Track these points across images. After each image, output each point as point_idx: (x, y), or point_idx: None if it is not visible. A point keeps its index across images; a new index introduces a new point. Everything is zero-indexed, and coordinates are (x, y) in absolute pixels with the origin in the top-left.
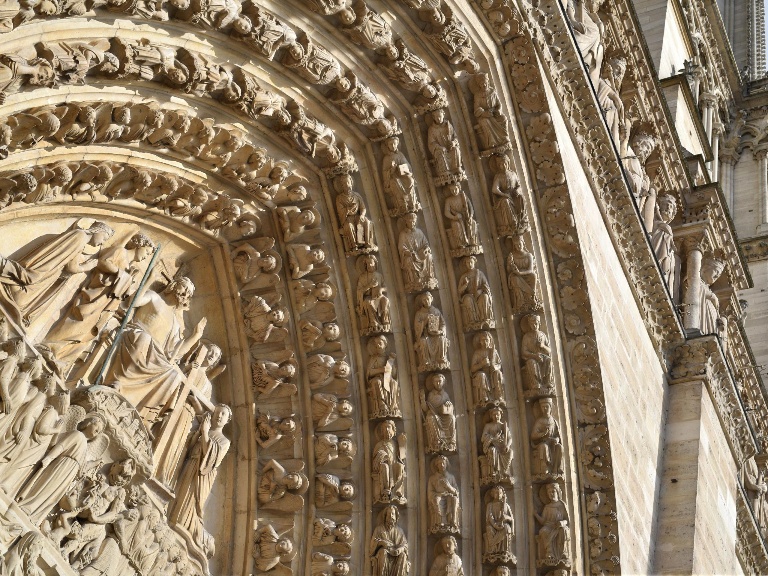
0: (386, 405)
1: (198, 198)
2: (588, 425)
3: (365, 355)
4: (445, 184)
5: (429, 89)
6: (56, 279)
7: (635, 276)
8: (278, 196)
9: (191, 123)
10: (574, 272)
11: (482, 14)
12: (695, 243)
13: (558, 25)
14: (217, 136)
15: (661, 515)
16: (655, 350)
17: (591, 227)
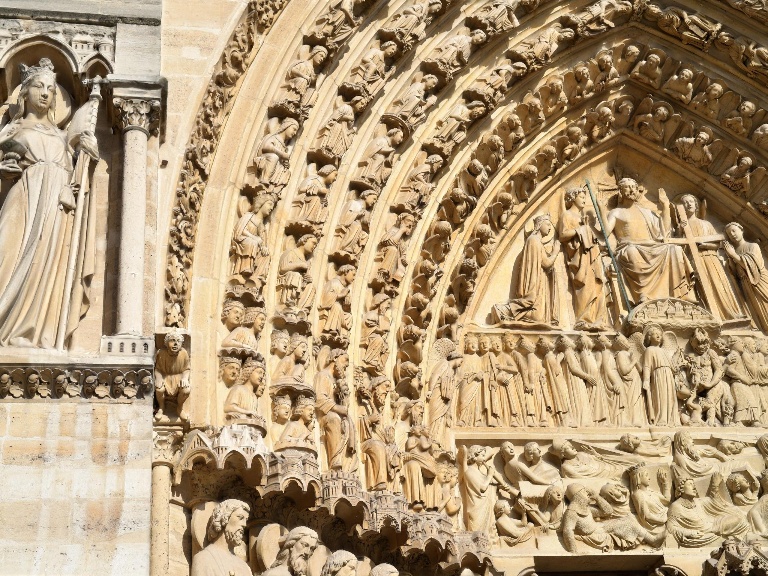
0: None
1: (574, 136)
2: None
3: None
4: None
5: None
6: (546, 280)
7: None
8: (622, 69)
9: (519, 111)
10: None
11: None
12: None
13: None
14: (543, 95)
15: None
16: None
17: None
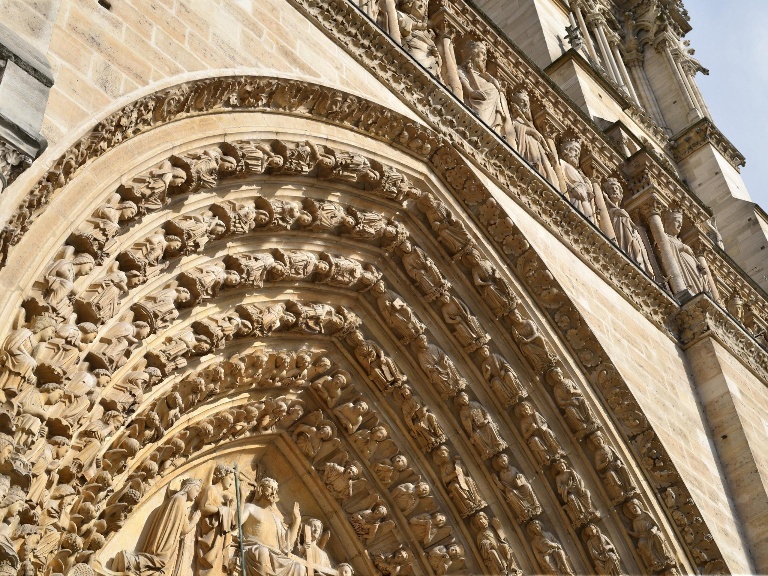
0: (471, 502)
1: (251, 416)
2: (637, 436)
3: (435, 467)
4: (436, 298)
5: (389, 231)
6: (178, 546)
7: (617, 280)
8: (308, 375)
9: (222, 367)
10: (570, 315)
11: (403, 148)
12: (650, 209)
13: (466, 121)
14: None
15: (726, 472)
16: (660, 330)
17: (566, 267)
